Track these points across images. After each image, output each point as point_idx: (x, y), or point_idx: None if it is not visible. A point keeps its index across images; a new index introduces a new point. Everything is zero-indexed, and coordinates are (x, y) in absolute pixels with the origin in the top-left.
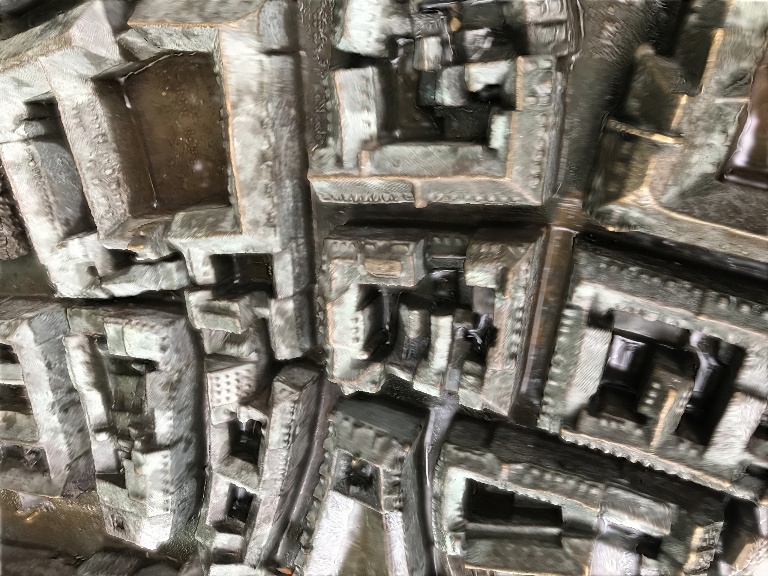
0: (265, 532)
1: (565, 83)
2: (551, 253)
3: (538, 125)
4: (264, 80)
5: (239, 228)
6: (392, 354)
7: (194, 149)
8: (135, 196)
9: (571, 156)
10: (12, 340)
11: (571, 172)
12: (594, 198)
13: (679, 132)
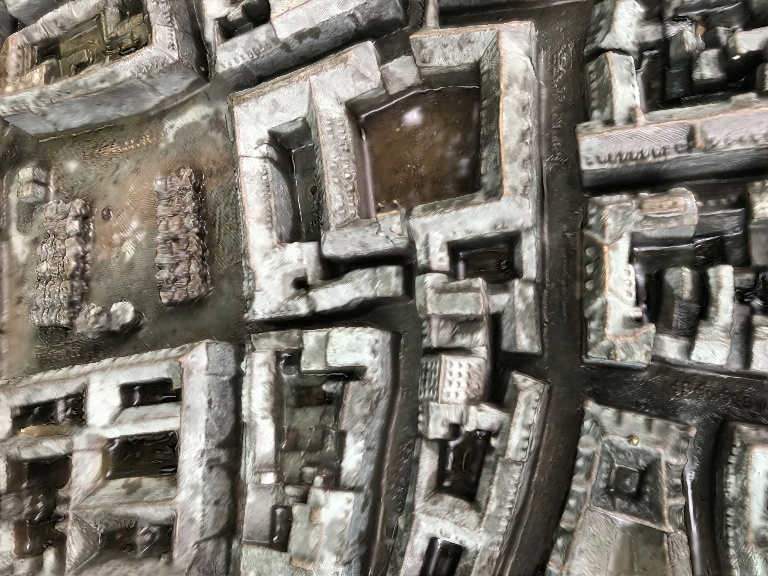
0: None
1: None
2: None
3: None
4: (527, 77)
5: (497, 195)
6: (658, 326)
7: (421, 173)
8: (362, 206)
9: None
10: (185, 361)
11: None
12: None
13: None
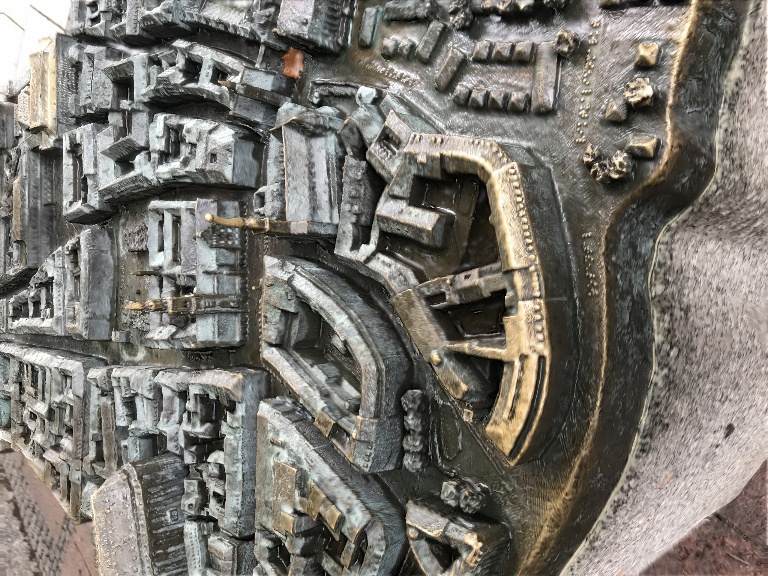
0: None
1: None
2: None
3: None
4: None
5: None
6: None
7: None
8: None
9: None
10: (150, 207)
11: None
12: None
13: None
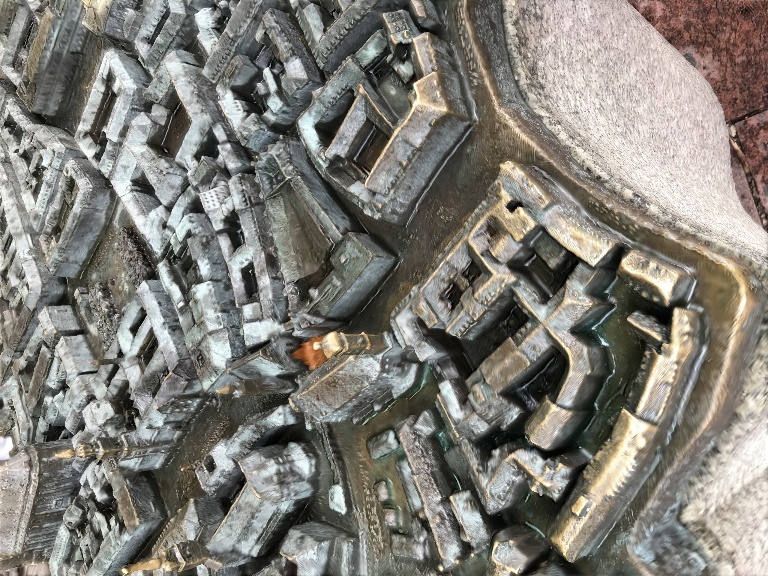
0: (267, 286)
1: None
2: None
3: None
4: (186, 70)
5: None
6: None
7: None
8: None
9: None
10: (138, 292)
11: None
12: None
13: None
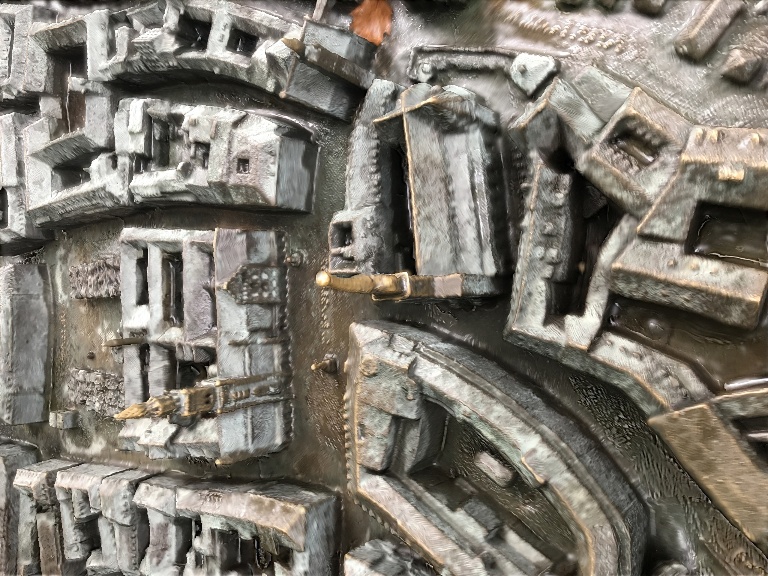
0: None
1: None
2: None
3: None
4: None
5: (85, 26)
6: None
7: None
8: None
9: None
10: (122, 238)
11: None
12: None
13: None
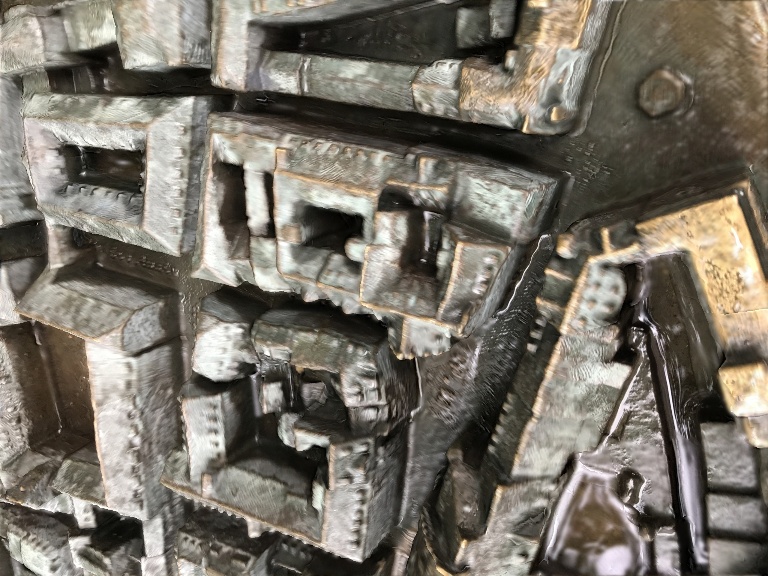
0: None
1: (394, 448)
2: (395, 575)
3: (354, 500)
4: (132, 378)
5: None
6: None
7: None
8: (37, 427)
9: (413, 494)
10: None
11: (412, 510)
12: (409, 571)
13: (463, 566)
